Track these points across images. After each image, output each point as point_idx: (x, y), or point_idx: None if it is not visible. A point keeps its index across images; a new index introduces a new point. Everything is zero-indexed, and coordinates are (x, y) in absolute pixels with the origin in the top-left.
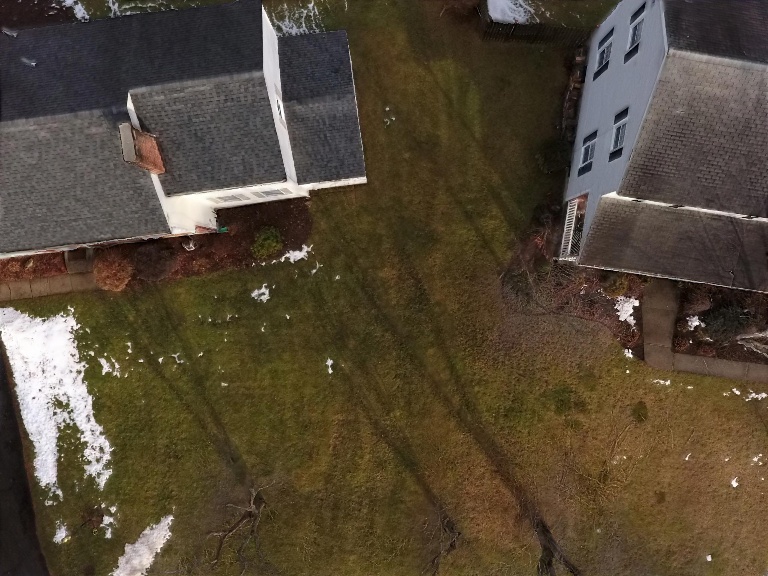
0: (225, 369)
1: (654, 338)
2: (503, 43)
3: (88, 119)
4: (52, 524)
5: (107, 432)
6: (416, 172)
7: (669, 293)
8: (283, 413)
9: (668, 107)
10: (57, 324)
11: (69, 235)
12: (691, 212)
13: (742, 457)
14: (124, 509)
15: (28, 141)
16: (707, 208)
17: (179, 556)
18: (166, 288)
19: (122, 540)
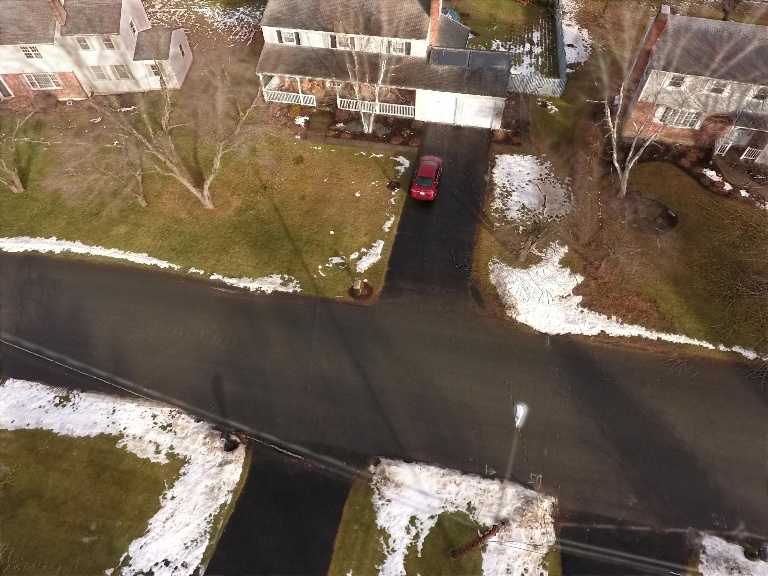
0: None
1: (315, 131)
2: None
3: (42, 0)
4: None
5: None
6: (209, 87)
7: (327, 116)
8: None
9: None
10: None
11: (6, 41)
12: (308, 47)
13: (364, 182)
14: None
15: (12, 6)
16: (301, 29)
17: None
18: (44, 116)
19: None
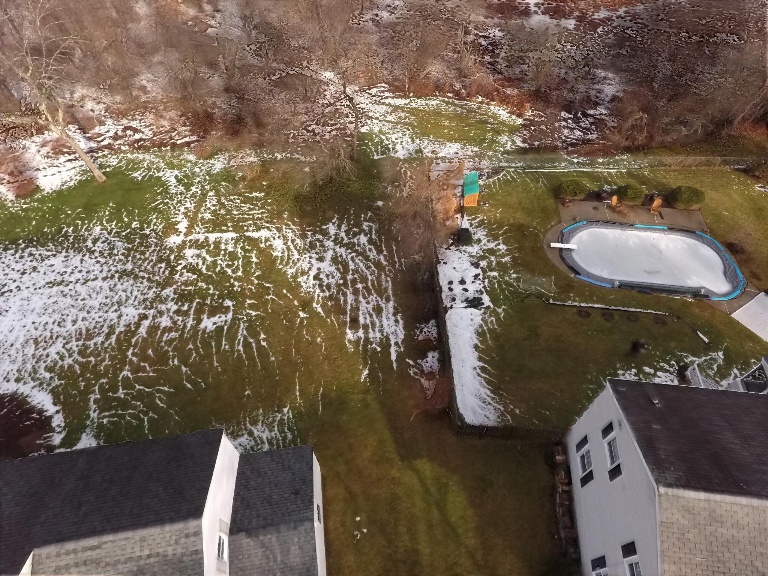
0: None
1: None
2: (478, 440)
3: None
4: None
5: None
6: None
7: None
8: None
9: (684, 553)
10: None
11: None
12: None
13: None
14: None
15: None
16: None
17: None
18: None
19: None
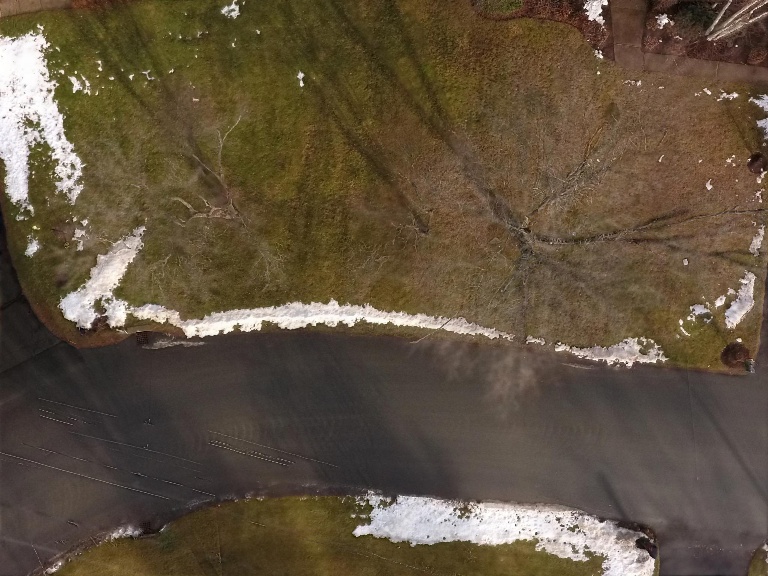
0: (196, 85)
1: (624, 38)
2: None
3: None
4: (23, 238)
5: (78, 149)
6: None
7: None
8: (255, 125)
9: None
10: (27, 42)
11: None
12: None
13: (715, 158)
14: (96, 222)
15: None
16: None
17: None
18: (136, 5)
19: (94, 251)
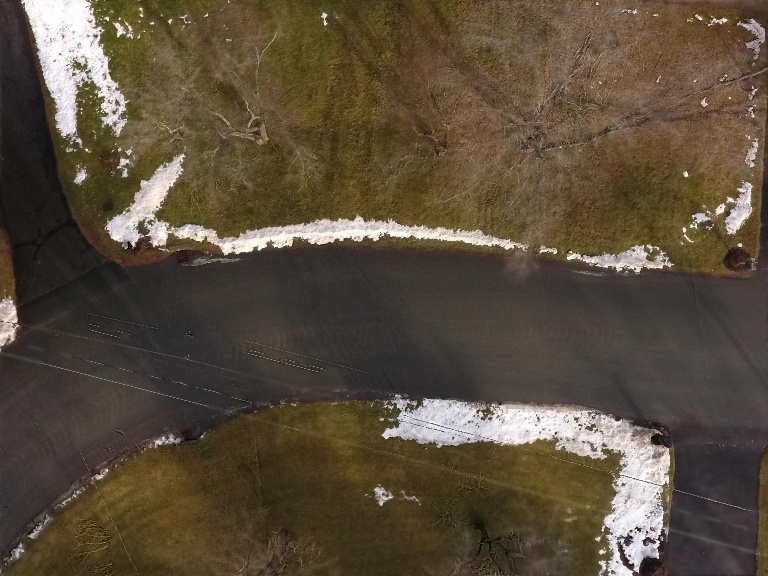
0: (229, 27)
1: None
2: None
3: None
4: (73, 168)
5: (122, 88)
6: None
7: None
8: (283, 61)
9: None
10: None
11: None
12: None
13: (709, 78)
14: (139, 151)
15: None
16: None
17: (191, 189)
18: None
19: (138, 177)
